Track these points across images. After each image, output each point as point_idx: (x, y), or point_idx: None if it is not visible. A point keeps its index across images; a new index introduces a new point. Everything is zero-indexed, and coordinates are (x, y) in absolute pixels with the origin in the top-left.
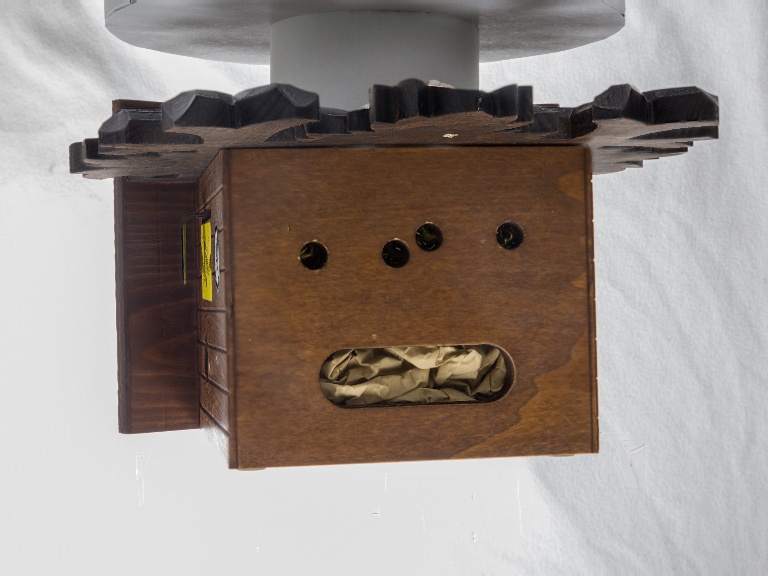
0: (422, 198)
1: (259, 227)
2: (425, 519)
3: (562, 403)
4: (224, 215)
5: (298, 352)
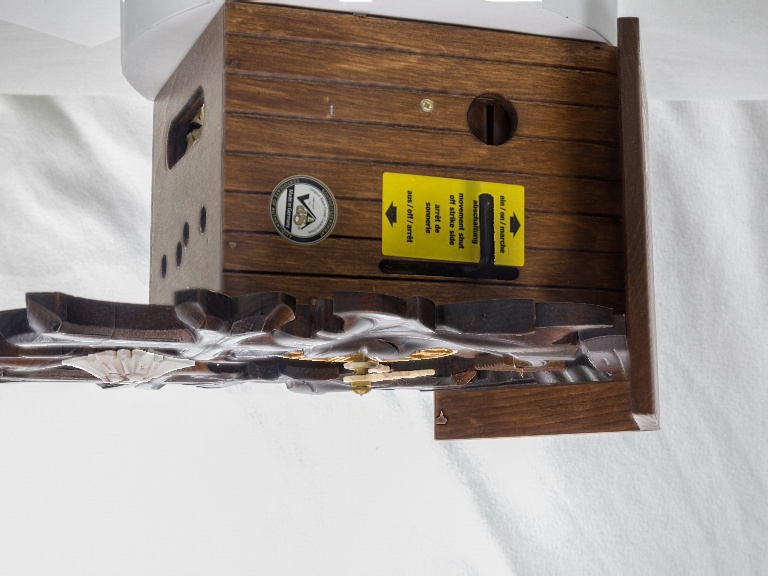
0: (179, 288)
1: (214, 238)
2: (125, 6)
3: (158, 134)
4: (222, 244)
5: (208, 127)
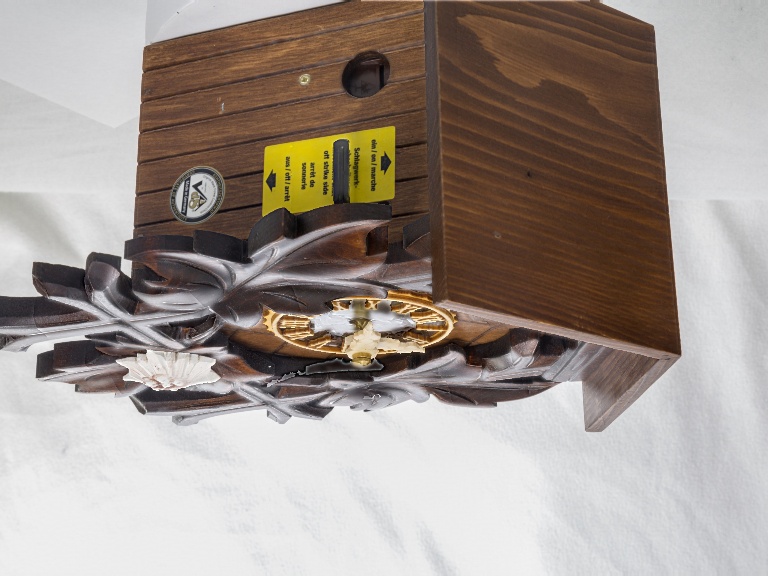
0: None
1: None
2: None
3: None
4: None
5: None
